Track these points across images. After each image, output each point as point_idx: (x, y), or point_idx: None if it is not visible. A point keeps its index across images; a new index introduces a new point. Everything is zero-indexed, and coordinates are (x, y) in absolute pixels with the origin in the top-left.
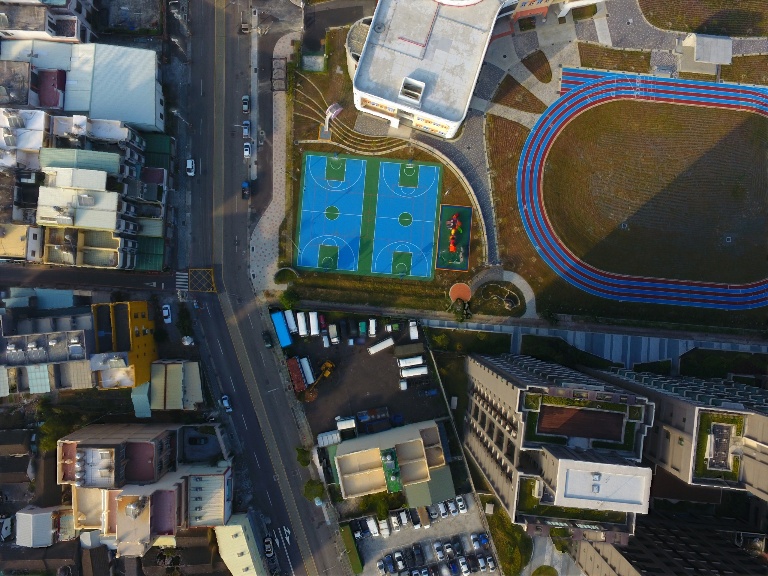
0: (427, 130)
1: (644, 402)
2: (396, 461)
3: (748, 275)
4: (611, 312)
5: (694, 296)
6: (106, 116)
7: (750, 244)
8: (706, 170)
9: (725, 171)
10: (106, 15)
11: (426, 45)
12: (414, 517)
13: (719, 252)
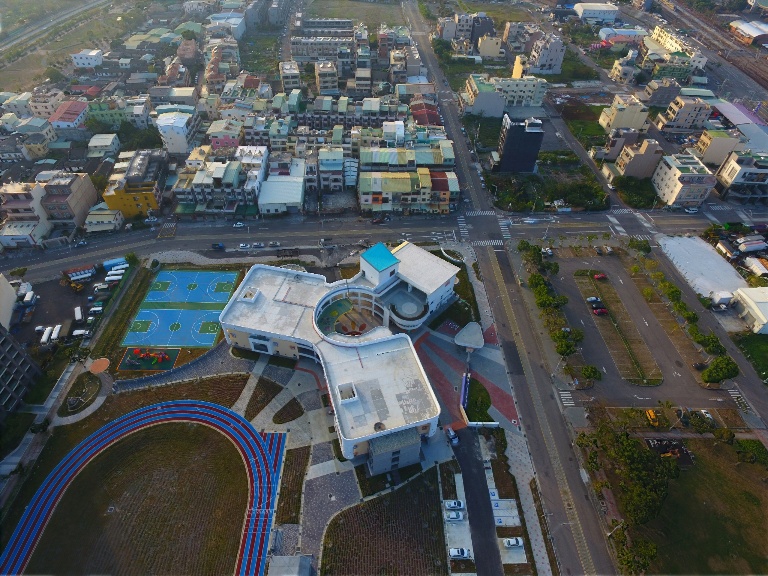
0: None
1: None
2: None
3: None
4: (20, 500)
5: None
6: (263, 187)
7: None
8: None
9: None
10: (329, 193)
11: (284, 301)
12: None
13: None
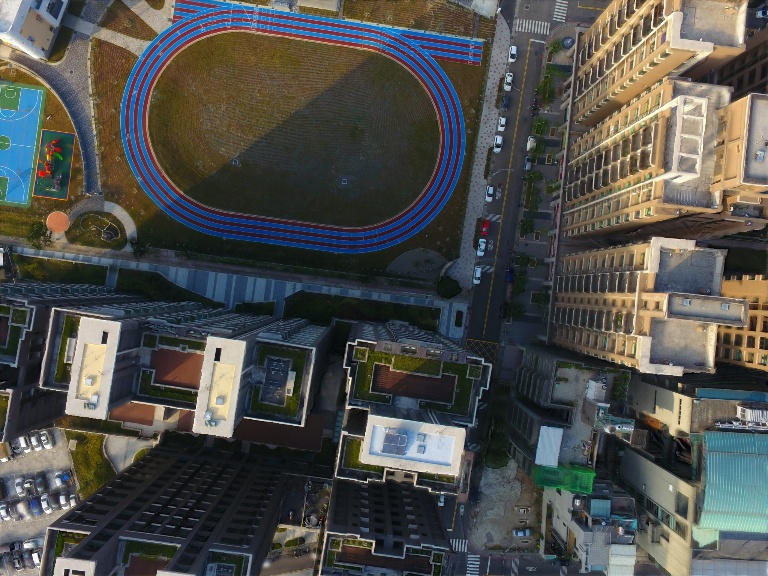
0: None
1: (25, 305)
2: None
3: (360, 218)
4: (216, 249)
5: (302, 237)
6: None
7: (366, 187)
8: (324, 109)
9: (344, 111)
10: None
11: None
12: None
13: (333, 194)
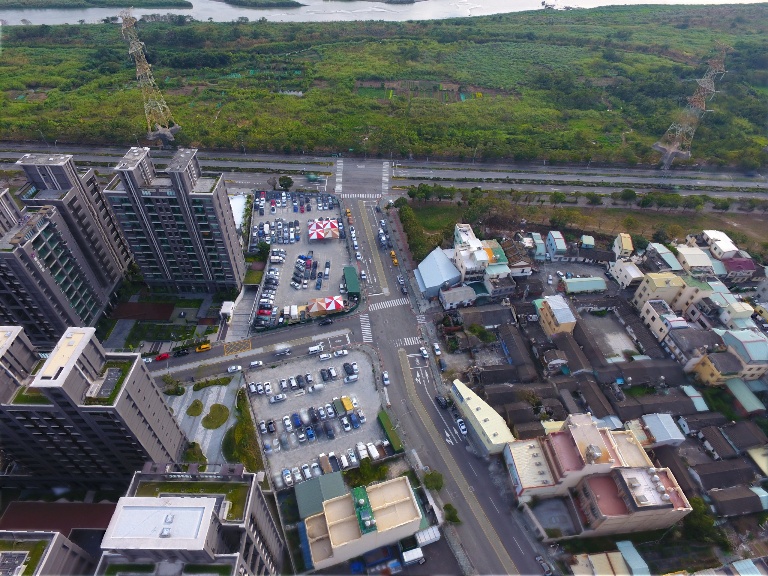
0: None
1: None
2: (360, 520)
3: None
4: None
5: None
6: None
7: None
8: None
9: None
10: None
11: None
12: (335, 463)
13: None
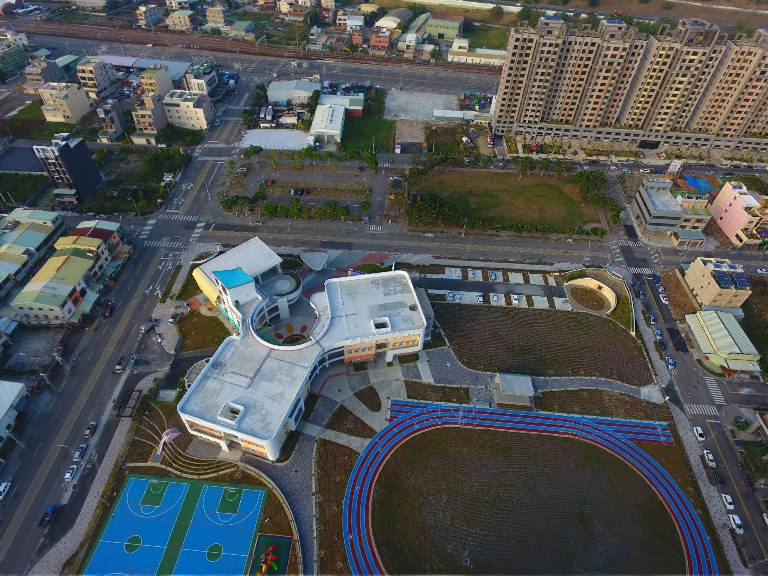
0: (256, 453)
1: None
2: None
3: None
4: None
5: None
6: None
7: None
8: (544, 495)
9: (565, 496)
10: (6, 359)
11: (253, 378)
12: None
13: None
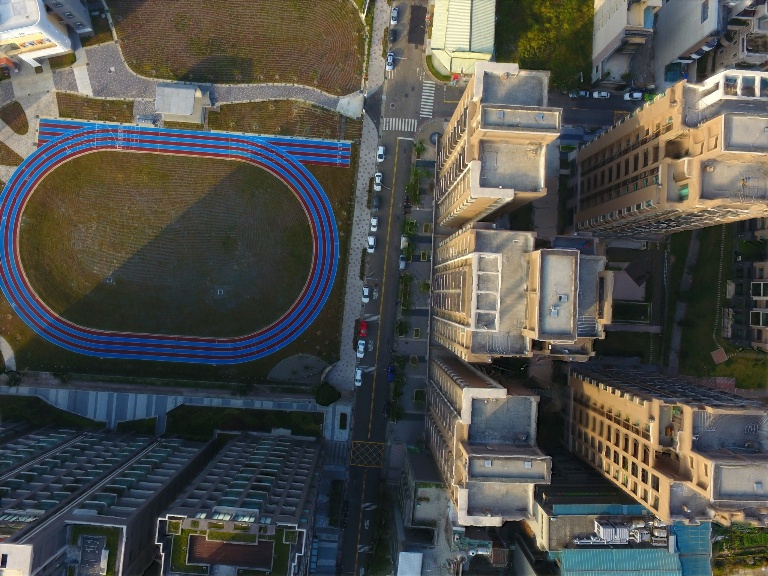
0: None
1: None
2: None
3: (237, 328)
4: (94, 369)
5: (180, 351)
6: None
7: (242, 296)
8: (195, 221)
9: (215, 222)
10: None
11: None
12: None
13: (209, 305)
